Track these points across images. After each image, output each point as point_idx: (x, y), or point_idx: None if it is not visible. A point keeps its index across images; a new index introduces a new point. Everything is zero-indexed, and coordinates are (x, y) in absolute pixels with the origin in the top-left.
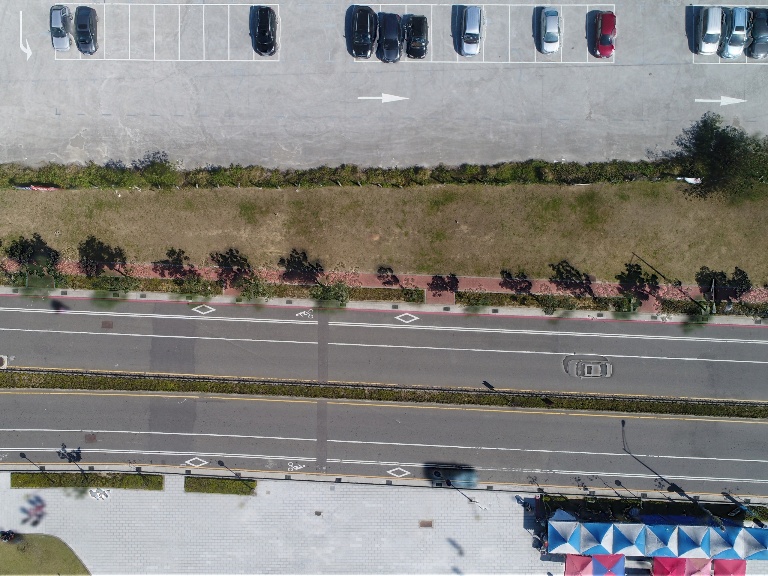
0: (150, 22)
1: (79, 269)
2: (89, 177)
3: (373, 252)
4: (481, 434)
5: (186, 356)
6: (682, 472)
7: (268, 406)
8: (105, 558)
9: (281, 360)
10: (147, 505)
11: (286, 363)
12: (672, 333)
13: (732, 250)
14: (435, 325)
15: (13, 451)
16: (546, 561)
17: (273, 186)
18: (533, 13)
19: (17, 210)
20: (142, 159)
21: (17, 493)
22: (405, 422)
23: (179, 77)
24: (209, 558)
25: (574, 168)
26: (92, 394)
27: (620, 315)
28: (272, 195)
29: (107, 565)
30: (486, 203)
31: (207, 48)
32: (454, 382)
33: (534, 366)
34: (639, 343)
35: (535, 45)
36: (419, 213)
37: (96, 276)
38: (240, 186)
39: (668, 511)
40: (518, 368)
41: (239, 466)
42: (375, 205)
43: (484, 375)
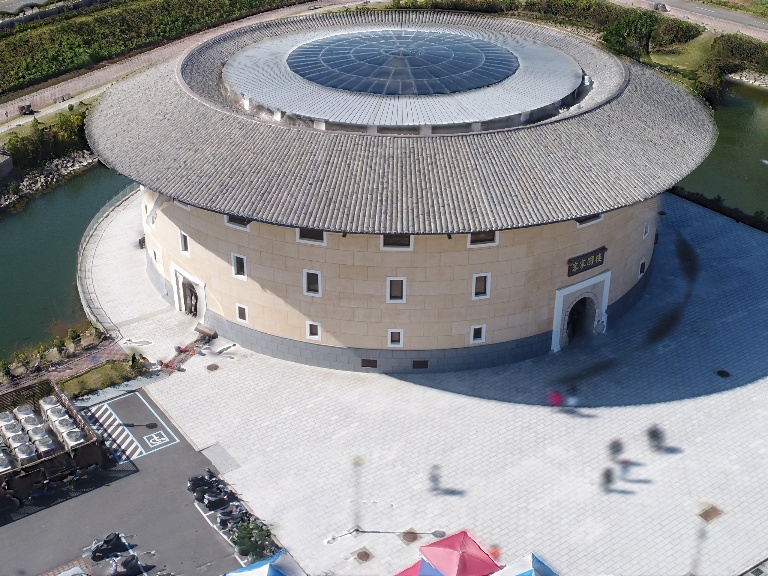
0: None
1: None
2: None
3: None
4: None
5: None
6: None
7: None
8: None
9: None
10: None
11: None
12: None
13: None
14: None
15: None
16: None
17: None
18: None
19: None
20: None
21: None
22: None
23: None
24: None
25: None
26: None
27: None
28: None
29: None
30: None
31: None
32: None
33: None
34: None
35: None
36: None
37: None
38: None
39: None
40: None
41: None
42: None
43: None
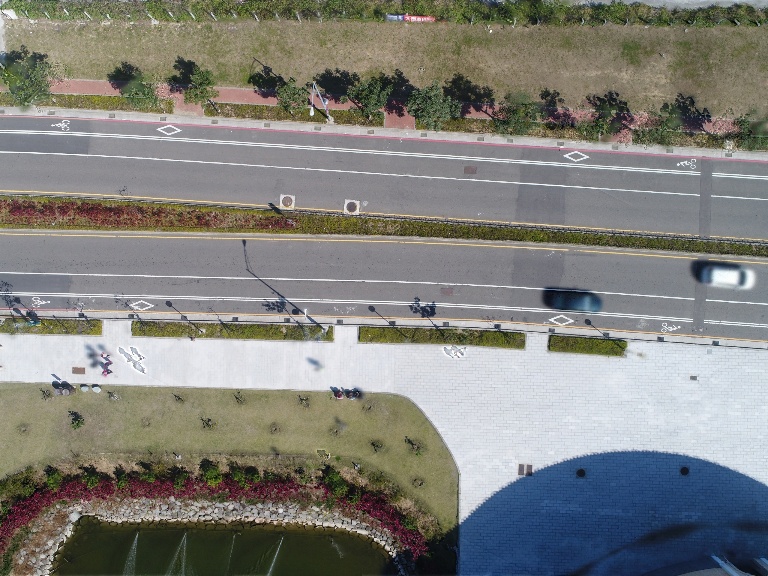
0: None
1: (442, 109)
2: (461, 9)
3: (766, 98)
4: None
5: (556, 206)
6: None
7: (643, 261)
8: (458, 420)
9: (659, 212)
10: (506, 365)
11: (665, 216)
12: None
13: None
14: None
15: (361, 304)
16: None
17: (666, 22)
18: None
19: (378, 44)
20: None
21: (364, 349)
22: None
23: None
24: (572, 423)
25: None
26: (451, 244)
27: None
28: (658, 34)
29: (460, 428)
30: None
31: None
32: None
33: None
34: None
35: None
36: None
37: (462, 117)
38: (629, 22)
39: None
40: None
41: (608, 325)
42: None
43: None
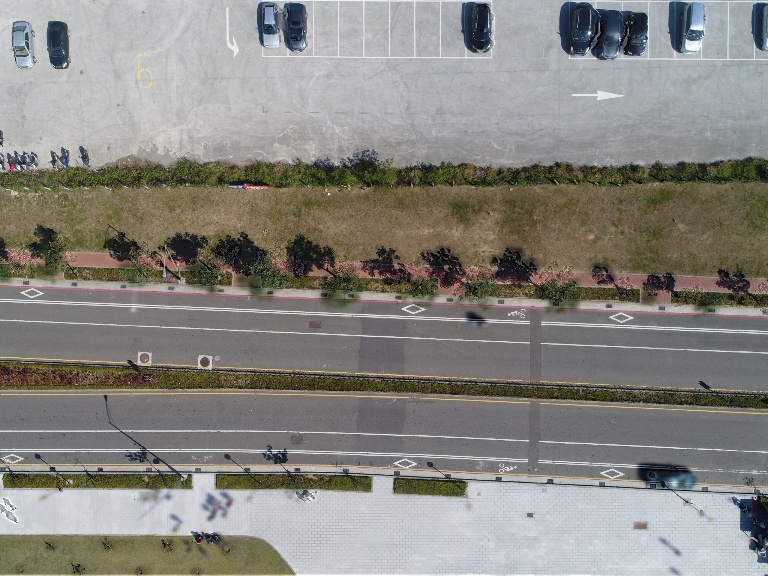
0: (360, 19)
1: (286, 268)
2: (299, 175)
3: (588, 251)
4: (697, 435)
5: (396, 356)
6: None
7: (479, 407)
8: (312, 560)
9: (493, 360)
10: (355, 507)
11: (498, 363)
12: None
13: None
14: (650, 325)
15: (218, 452)
16: (763, 563)
17: (489, 184)
18: (753, 10)
19: (224, 209)
20: (352, 157)
21: (222, 495)
22: (619, 423)
23: (389, 74)
24: (418, 560)
25: None
26: (299, 395)
27: None
28: (485, 193)
29: (314, 567)
30: (704, 201)
31: (418, 45)
32: (670, 382)
33: (752, 366)
34: None
35: (754, 42)
36: (635, 212)
37: (304, 275)
38: (455, 184)
39: None
40: (735, 368)
41: (449, 467)
42: (590, 204)
43: (701, 375)
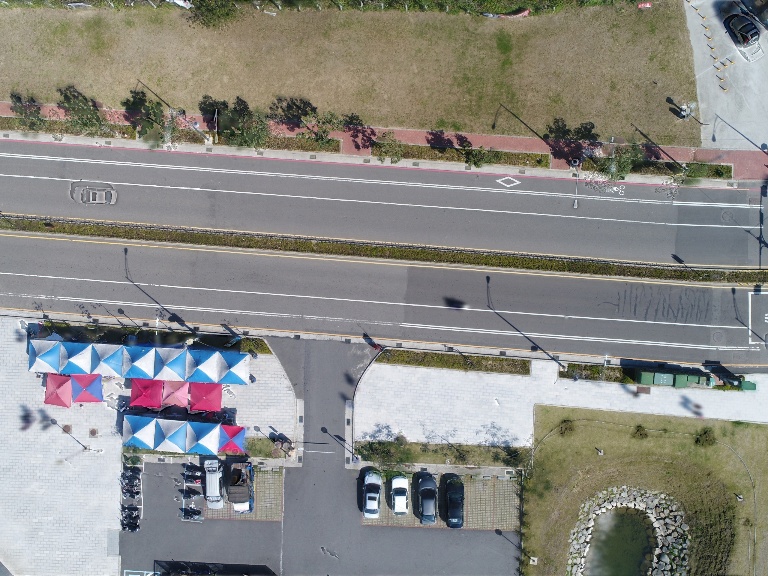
0: None
1: None
2: None
3: None
4: None
5: None
6: (182, 302)
7: None
8: None
9: None
10: None
11: None
12: (176, 162)
13: (234, 79)
14: None
15: None
16: None
17: None
18: None
19: None
20: None
21: None
22: None
23: None
24: None
25: None
26: None
27: (127, 143)
28: None
29: None
30: None
31: None
32: None
33: (41, 191)
34: (144, 171)
35: None
36: None
37: None
38: None
39: (166, 340)
40: (25, 193)
41: None
42: None
43: None
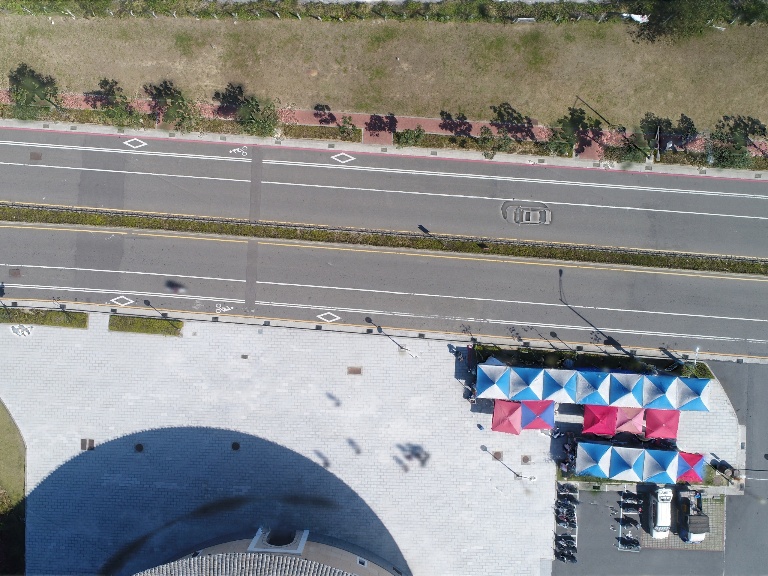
0: None
1: (9, 98)
2: (22, 1)
3: (310, 88)
4: (414, 279)
5: (115, 191)
6: (619, 325)
7: (197, 244)
8: (25, 397)
9: (212, 197)
10: (70, 343)
11: (217, 201)
12: (614, 181)
13: (679, 96)
14: (372, 166)
15: None
16: (476, 412)
17: (209, 14)
18: None
19: None
20: None
21: None
22: (337, 265)
23: None
24: (131, 400)
25: (519, 7)
26: (18, 227)
27: (562, 161)
28: (209, 26)
29: (27, 404)
30: (428, 40)
31: None
32: (389, 225)
33: (471, 211)
34: (580, 190)
35: None
36: (359, 49)
37: (26, 105)
38: (176, 14)
39: (603, 364)
40: (455, 212)
41: (166, 306)
42: (314, 40)
43: (420, 219)
